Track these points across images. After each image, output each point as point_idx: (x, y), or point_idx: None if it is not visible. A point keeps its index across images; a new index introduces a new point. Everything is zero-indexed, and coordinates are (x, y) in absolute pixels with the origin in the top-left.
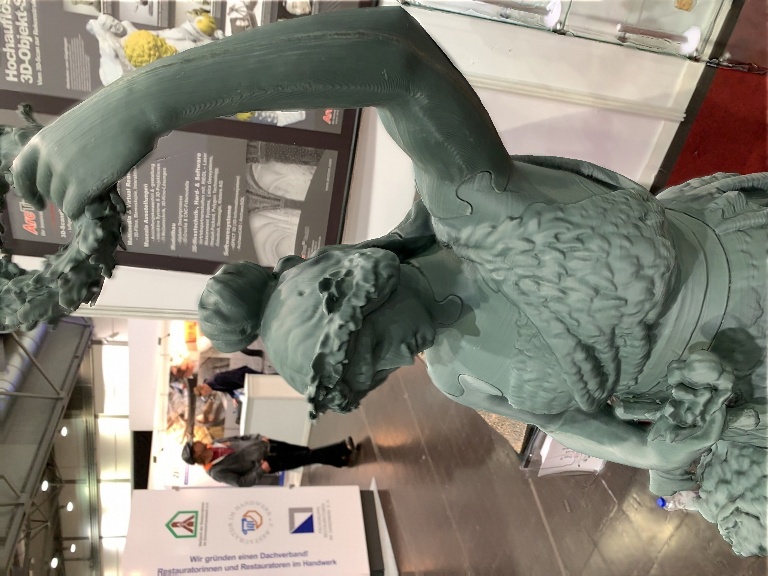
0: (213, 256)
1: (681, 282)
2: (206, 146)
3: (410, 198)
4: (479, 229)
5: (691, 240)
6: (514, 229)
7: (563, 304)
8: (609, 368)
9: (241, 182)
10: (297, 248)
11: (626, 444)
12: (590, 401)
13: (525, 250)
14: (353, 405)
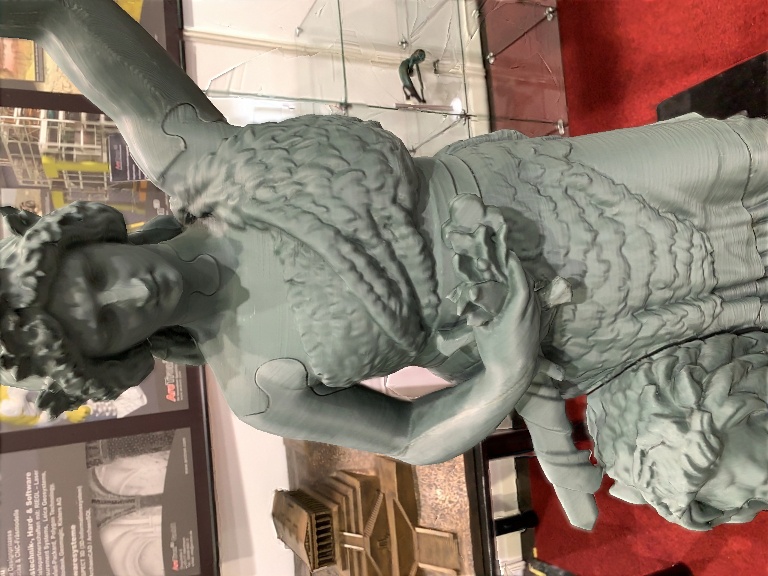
0: None
1: (426, 178)
2: (37, 463)
3: (282, 459)
4: (200, 163)
5: None
6: (231, 145)
7: (304, 195)
8: (393, 272)
9: (84, 492)
10: (166, 554)
11: (472, 392)
12: (389, 313)
13: (248, 159)
14: (85, 375)
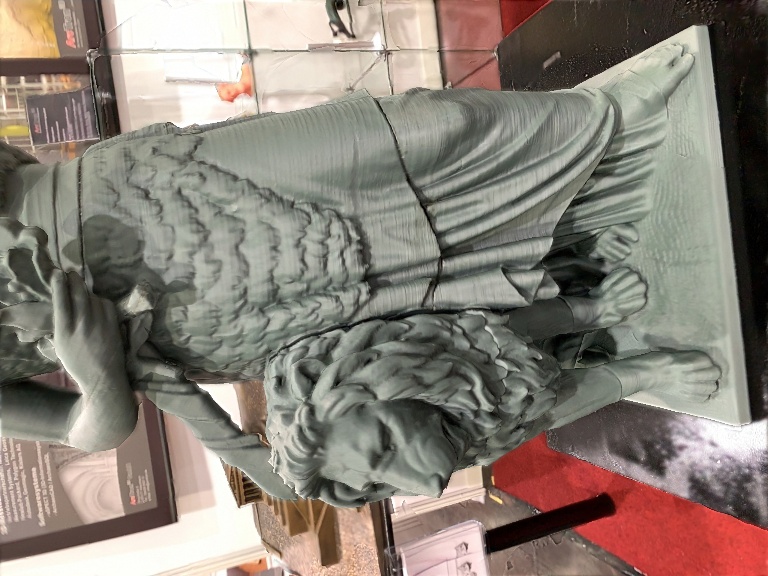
0: (27, 531)
1: (23, 191)
2: None
3: (234, 401)
4: None
5: (48, 164)
6: None
7: None
8: None
9: None
10: (123, 491)
11: None
12: None
13: None
14: None
